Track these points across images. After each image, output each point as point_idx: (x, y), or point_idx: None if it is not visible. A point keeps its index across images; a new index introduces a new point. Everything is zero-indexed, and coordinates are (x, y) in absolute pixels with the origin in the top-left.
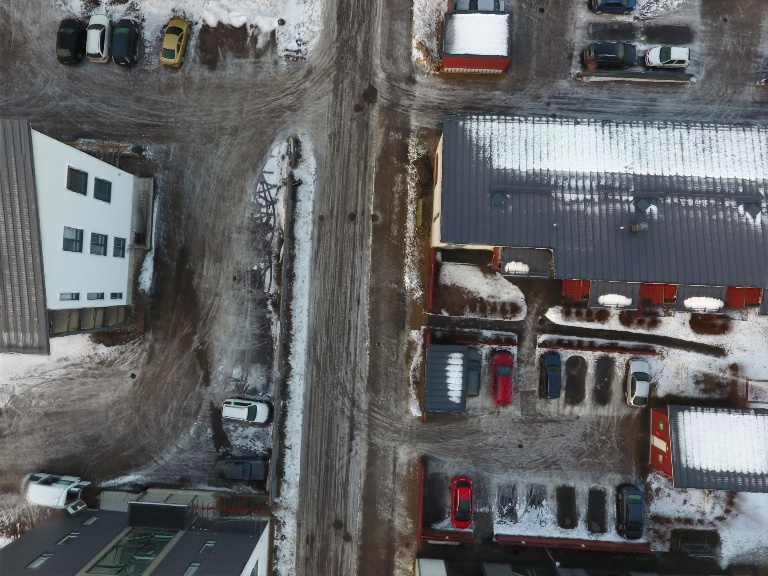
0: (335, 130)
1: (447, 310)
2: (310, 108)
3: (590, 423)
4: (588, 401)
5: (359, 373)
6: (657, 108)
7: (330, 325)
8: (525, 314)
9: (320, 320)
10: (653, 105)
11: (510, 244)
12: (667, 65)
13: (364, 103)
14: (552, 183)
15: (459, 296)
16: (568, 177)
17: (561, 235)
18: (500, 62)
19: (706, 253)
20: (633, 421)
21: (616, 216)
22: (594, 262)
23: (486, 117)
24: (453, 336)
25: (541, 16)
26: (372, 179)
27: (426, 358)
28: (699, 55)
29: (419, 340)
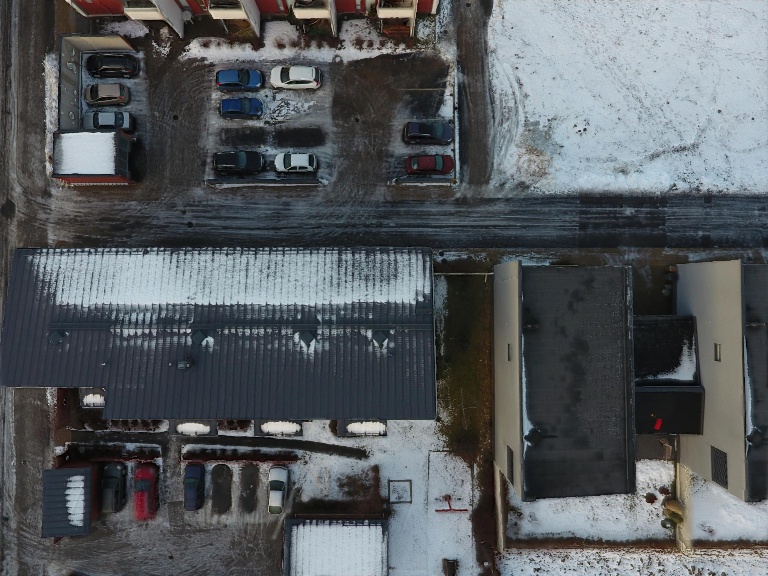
0: None
1: (90, 425)
2: None
3: (237, 531)
4: (234, 509)
5: (7, 492)
6: (291, 212)
7: None
8: (168, 425)
9: None
10: (287, 209)
11: (62, 385)
12: (293, 170)
13: (2, 218)
14: (112, 318)
15: (100, 411)
16: (130, 311)
17: (114, 373)
18: (113, 179)
19: (256, 385)
20: (279, 527)
21: (172, 350)
22: (143, 400)
23: (56, 250)
24: (93, 452)
25: (175, 123)
26: None
27: (43, 484)
28: (331, 157)
29: None
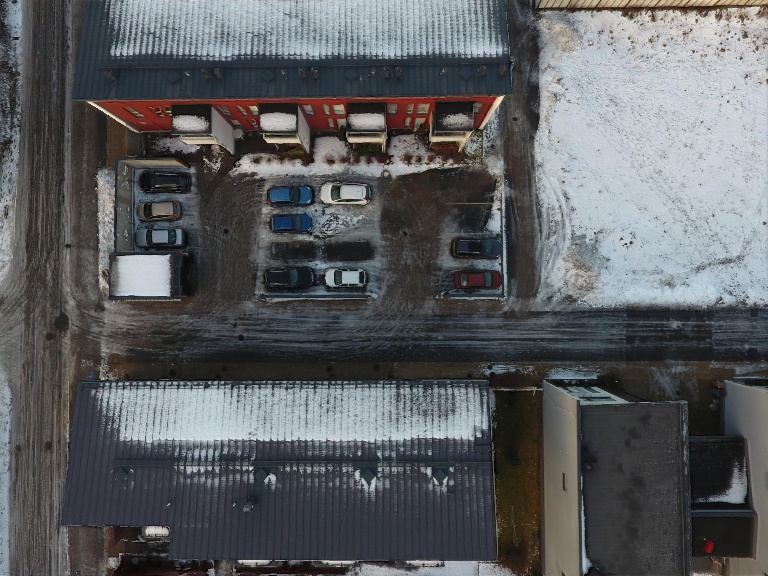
0: (28, 359)
1: None
2: (3, 338)
3: None
4: None
5: None
6: (341, 325)
7: (31, 555)
8: None
9: (21, 550)
10: (337, 322)
11: (128, 524)
12: (343, 286)
13: (56, 331)
14: (176, 454)
15: None
16: (192, 447)
17: (179, 512)
18: None
19: (319, 525)
20: None
21: (235, 488)
22: (208, 540)
23: (119, 384)
24: (147, 564)
25: (225, 237)
26: (67, 407)
27: None
28: (380, 270)
29: (117, 567)
